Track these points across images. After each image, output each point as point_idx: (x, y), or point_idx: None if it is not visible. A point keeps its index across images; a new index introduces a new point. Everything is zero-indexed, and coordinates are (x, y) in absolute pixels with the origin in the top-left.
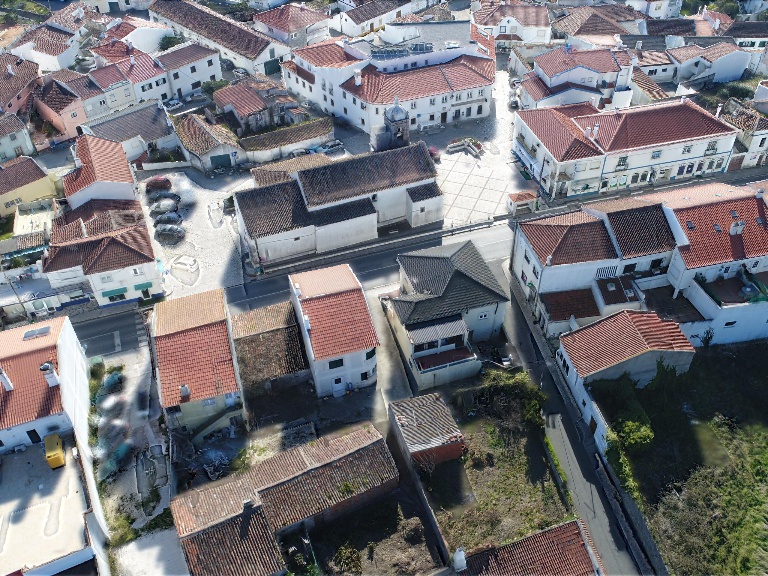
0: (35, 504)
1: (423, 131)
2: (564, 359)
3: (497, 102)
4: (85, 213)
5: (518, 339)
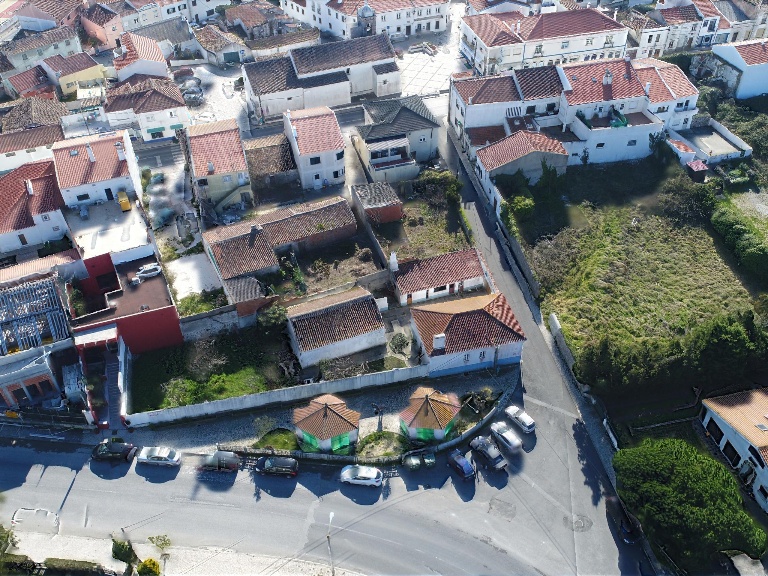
0: (113, 228)
1: (391, 39)
2: (479, 167)
3: (453, 22)
4: (131, 82)
5: (450, 161)
